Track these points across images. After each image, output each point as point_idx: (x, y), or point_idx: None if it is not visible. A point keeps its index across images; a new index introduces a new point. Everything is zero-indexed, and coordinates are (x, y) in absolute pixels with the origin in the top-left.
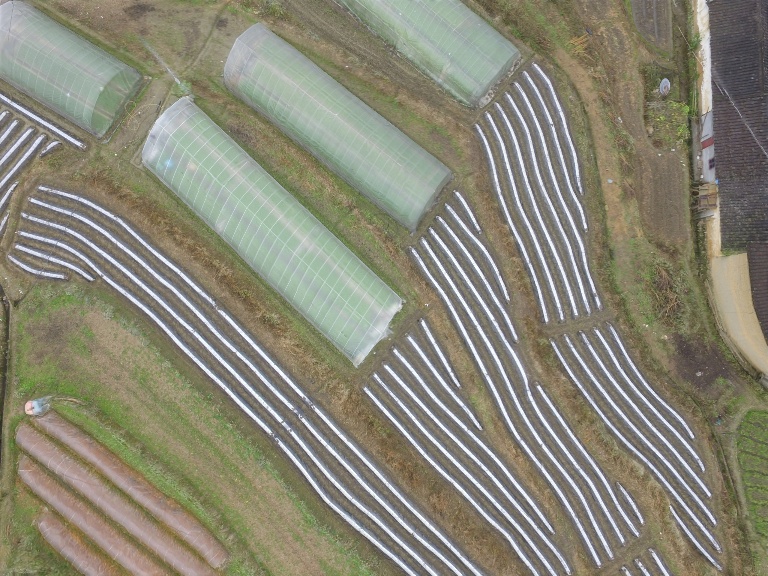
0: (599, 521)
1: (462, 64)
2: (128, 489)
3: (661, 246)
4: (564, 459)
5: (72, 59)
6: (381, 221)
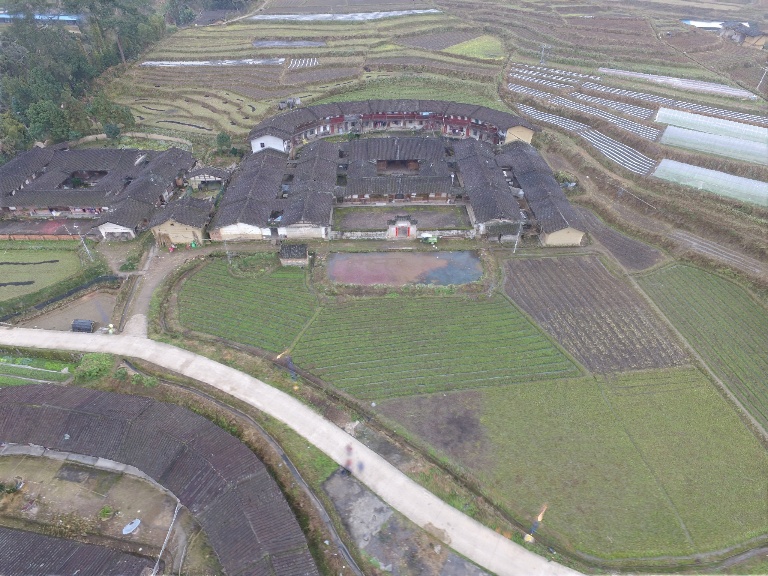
0: None
1: None
2: (711, 89)
3: (554, 151)
4: None
5: None
6: None
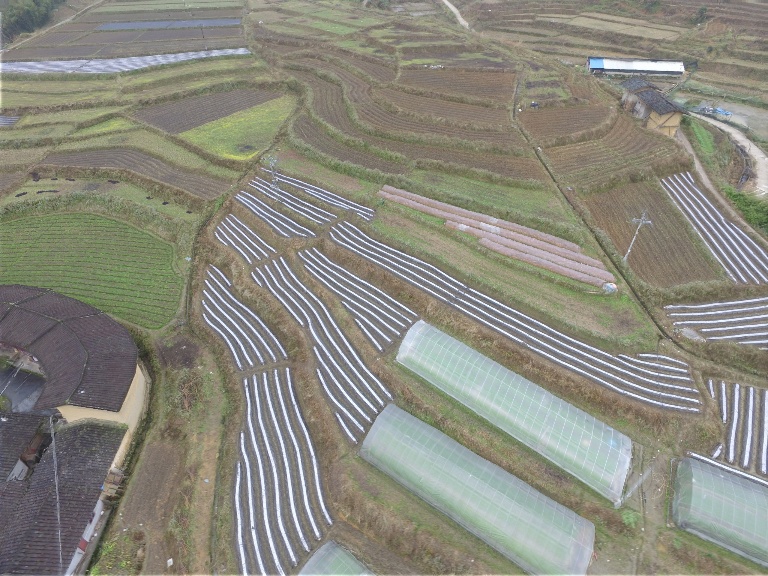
0: (277, 273)
1: (347, 574)
2: (539, 259)
3: (175, 436)
4: (292, 295)
5: (742, 510)
6: (418, 416)
